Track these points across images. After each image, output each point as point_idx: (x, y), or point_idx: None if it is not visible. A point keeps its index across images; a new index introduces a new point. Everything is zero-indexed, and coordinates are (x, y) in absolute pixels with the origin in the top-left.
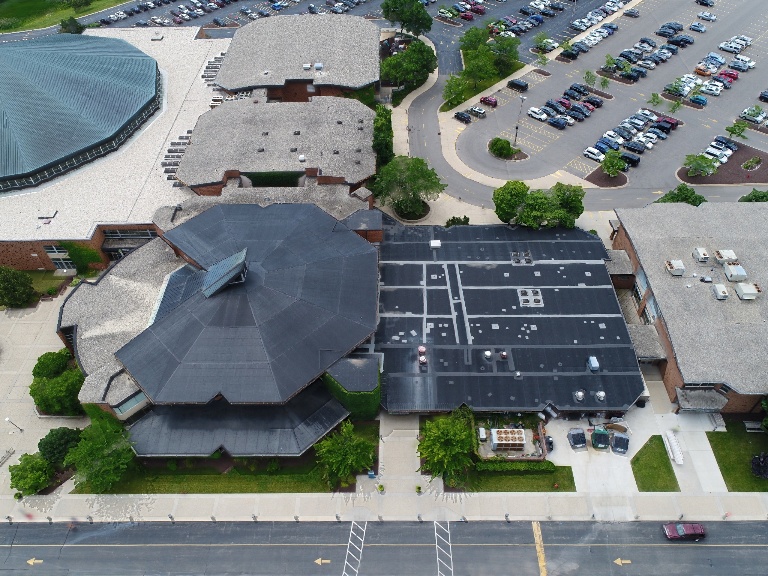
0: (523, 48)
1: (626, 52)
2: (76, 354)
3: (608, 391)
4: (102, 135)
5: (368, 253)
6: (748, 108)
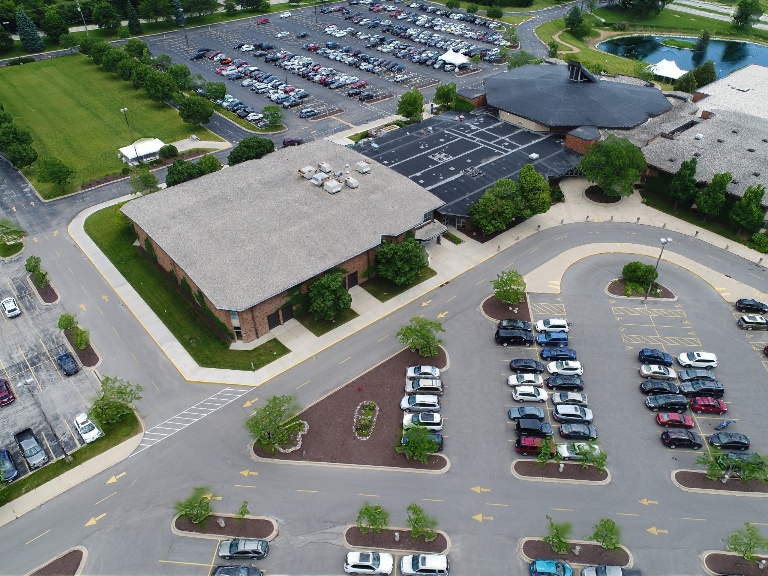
0: None
1: None
2: (592, 73)
3: (359, 148)
4: None
5: (549, 120)
6: None
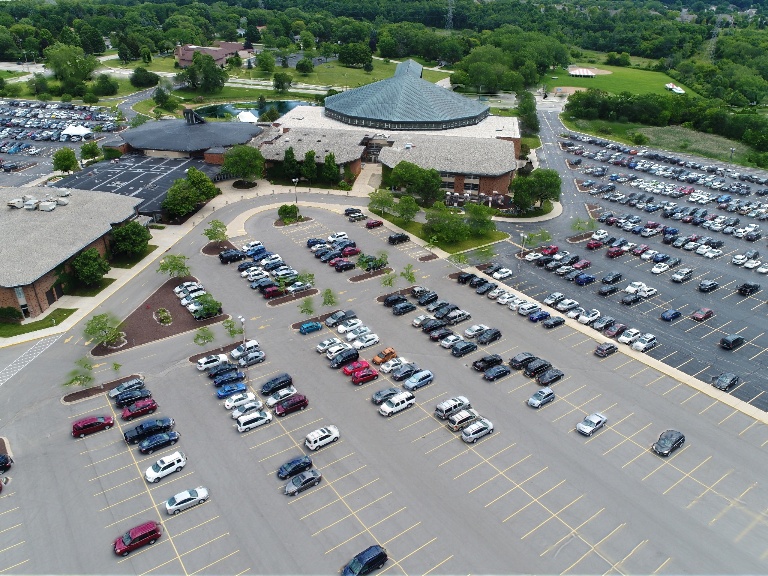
0: (497, 260)
1: (454, 306)
2: None
3: None
4: (350, 113)
5: None
6: (263, 351)
